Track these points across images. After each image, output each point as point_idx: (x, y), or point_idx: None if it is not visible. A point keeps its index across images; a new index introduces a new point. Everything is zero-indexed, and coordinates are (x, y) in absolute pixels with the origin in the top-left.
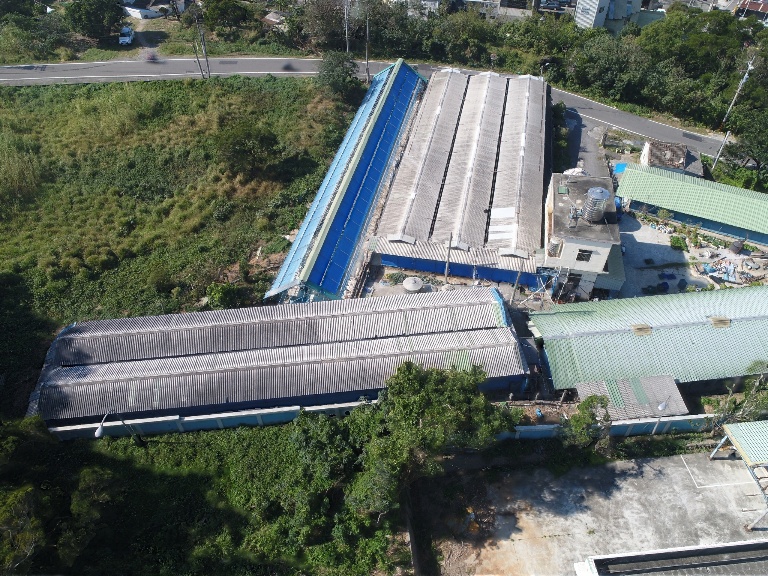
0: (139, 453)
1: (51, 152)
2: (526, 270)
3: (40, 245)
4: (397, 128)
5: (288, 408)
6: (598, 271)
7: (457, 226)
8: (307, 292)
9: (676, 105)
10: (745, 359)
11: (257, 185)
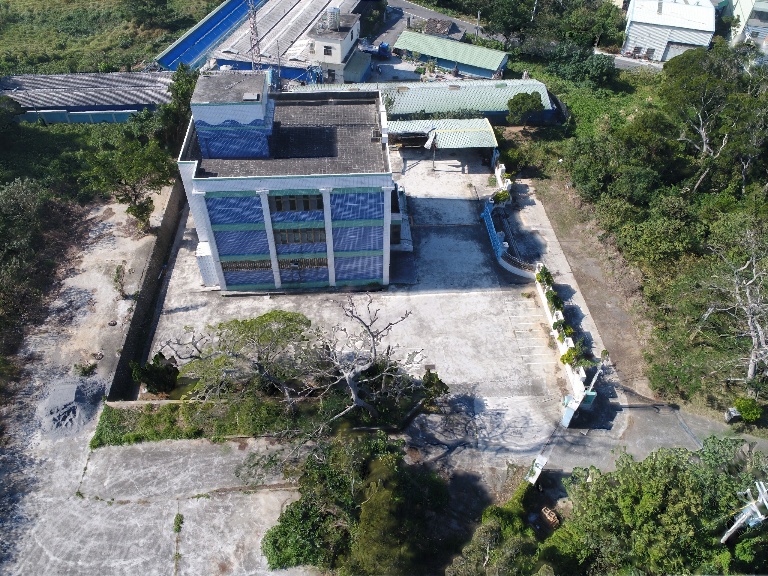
0: (42, 127)
1: (16, 9)
2: (301, 67)
3: (0, 47)
4: (255, 3)
5: (130, 111)
6: (339, 63)
7: (267, 46)
8: (160, 70)
9: (475, 9)
10: (410, 106)
11: (152, 31)
